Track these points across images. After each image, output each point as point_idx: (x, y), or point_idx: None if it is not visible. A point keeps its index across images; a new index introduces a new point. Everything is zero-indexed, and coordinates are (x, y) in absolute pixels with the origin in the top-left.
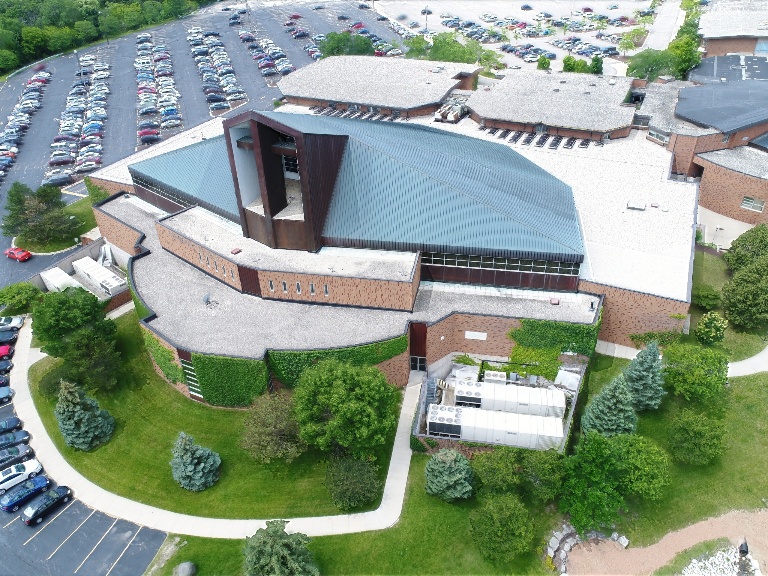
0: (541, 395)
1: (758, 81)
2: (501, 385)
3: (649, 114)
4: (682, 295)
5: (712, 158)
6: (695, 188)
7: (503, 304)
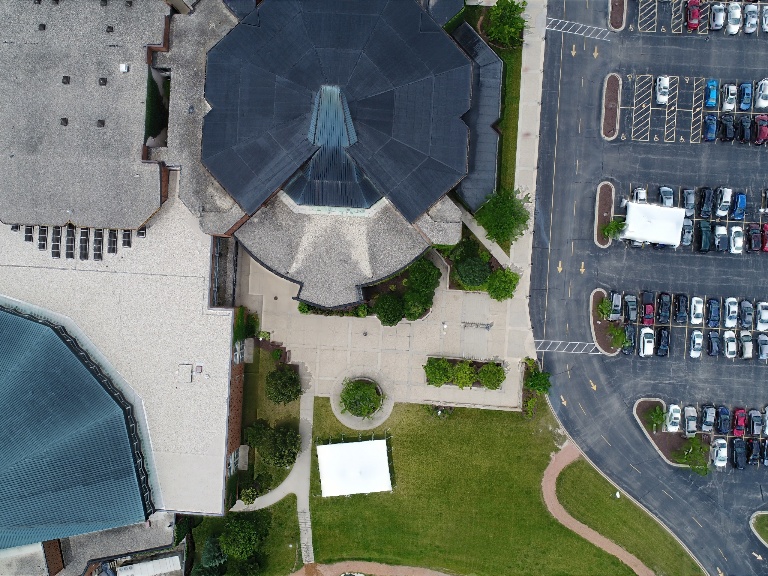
0: (167, 564)
1: (295, 4)
2: (143, 564)
3: (177, 161)
4: (219, 507)
5: (247, 239)
6: (230, 323)
7: (117, 537)
